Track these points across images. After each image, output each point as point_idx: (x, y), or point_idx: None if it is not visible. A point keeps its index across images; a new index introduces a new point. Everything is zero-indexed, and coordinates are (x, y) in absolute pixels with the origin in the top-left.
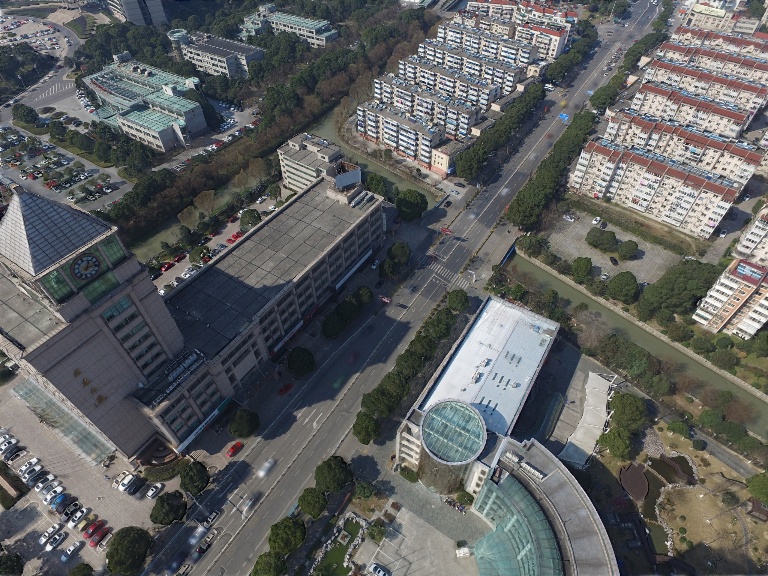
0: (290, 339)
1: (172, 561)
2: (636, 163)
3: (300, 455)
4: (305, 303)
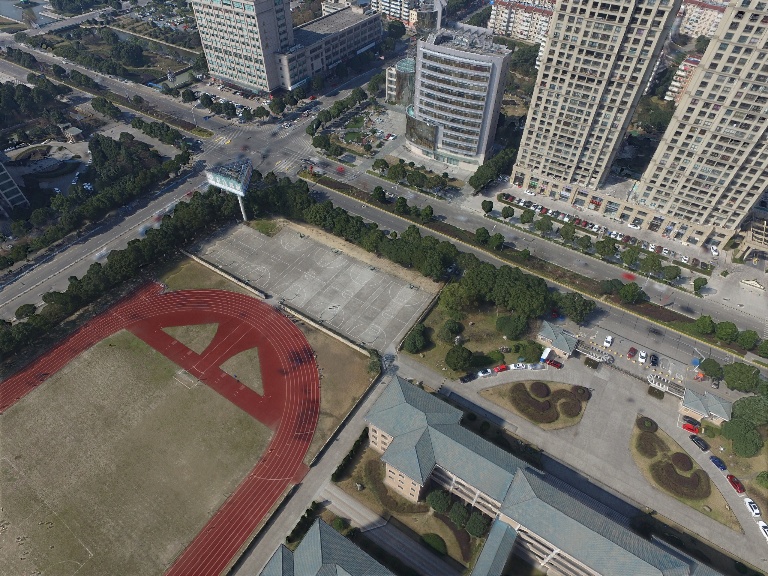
0: None
1: (293, 118)
2: (519, 8)
3: None
4: (343, 52)
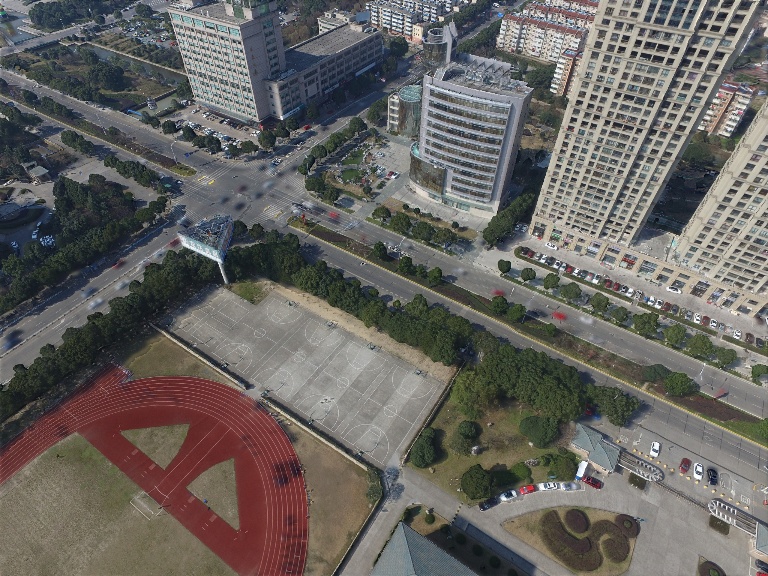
0: (331, 95)
1: None
2: (532, 23)
3: (340, 129)
4: (340, 74)
